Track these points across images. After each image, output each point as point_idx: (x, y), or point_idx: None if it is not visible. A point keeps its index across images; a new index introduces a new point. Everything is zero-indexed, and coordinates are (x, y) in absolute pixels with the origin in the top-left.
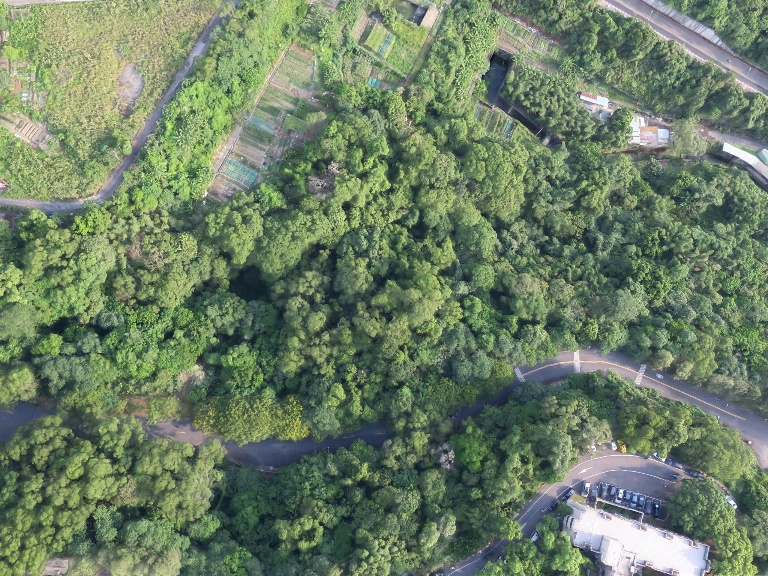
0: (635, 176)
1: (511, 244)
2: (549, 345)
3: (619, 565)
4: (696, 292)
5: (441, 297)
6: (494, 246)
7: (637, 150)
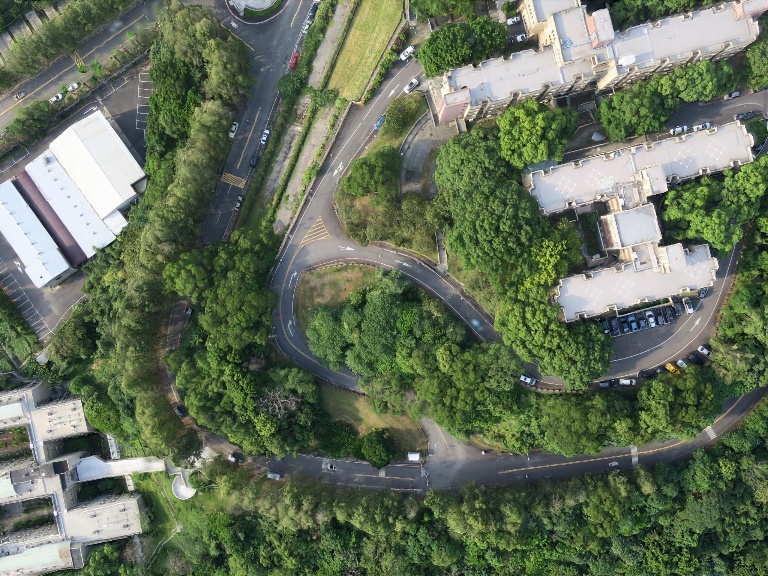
0: None
1: None
2: (759, 426)
3: (648, 251)
4: None
5: None
6: None
7: None
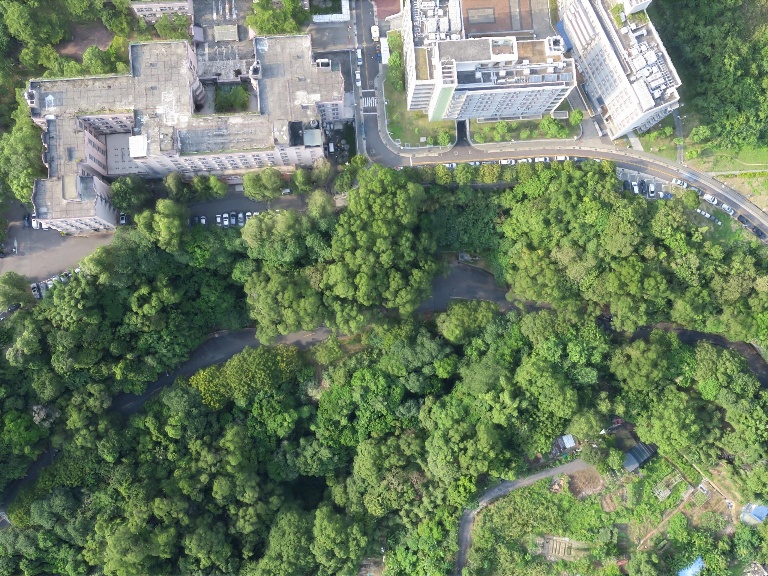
0: None
1: None
2: None
3: None
4: None
5: None
6: None
7: None
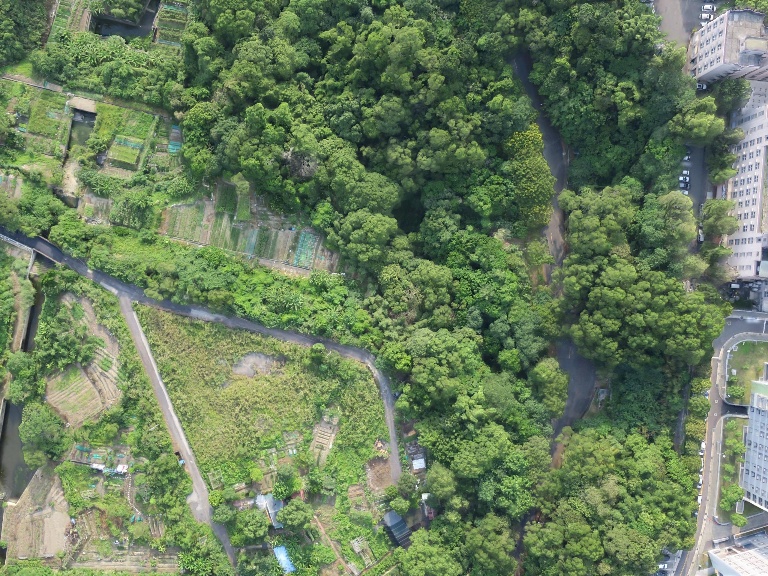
0: None
1: None
2: None
3: None
4: None
5: None
6: None
7: None
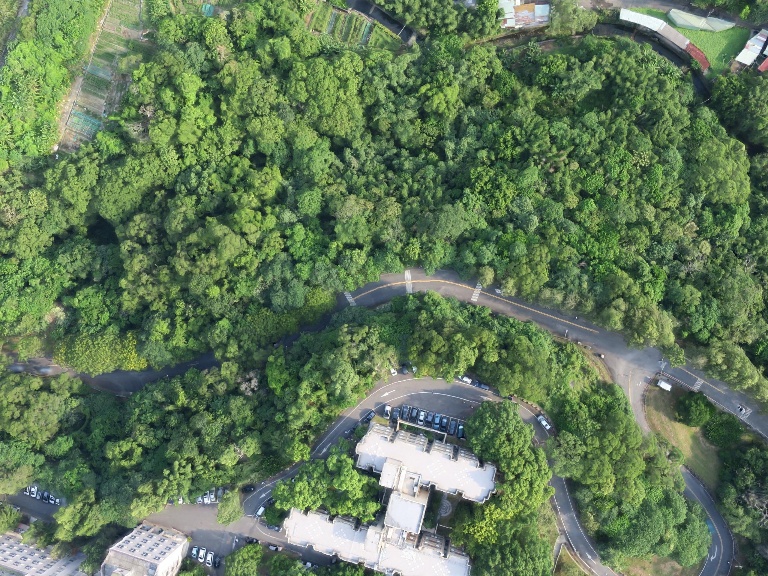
0: (494, 69)
1: (350, 163)
2: (371, 268)
3: (403, 485)
4: (550, 196)
5: (264, 228)
6: (335, 167)
7: (519, 33)
